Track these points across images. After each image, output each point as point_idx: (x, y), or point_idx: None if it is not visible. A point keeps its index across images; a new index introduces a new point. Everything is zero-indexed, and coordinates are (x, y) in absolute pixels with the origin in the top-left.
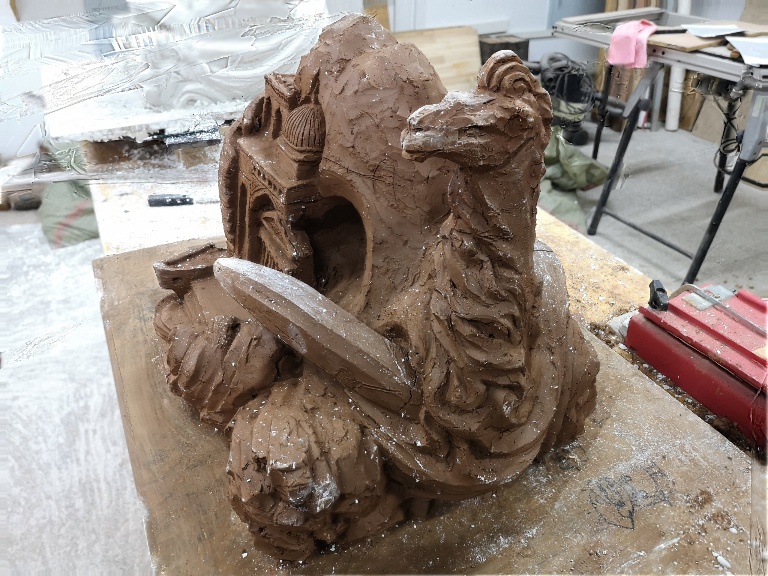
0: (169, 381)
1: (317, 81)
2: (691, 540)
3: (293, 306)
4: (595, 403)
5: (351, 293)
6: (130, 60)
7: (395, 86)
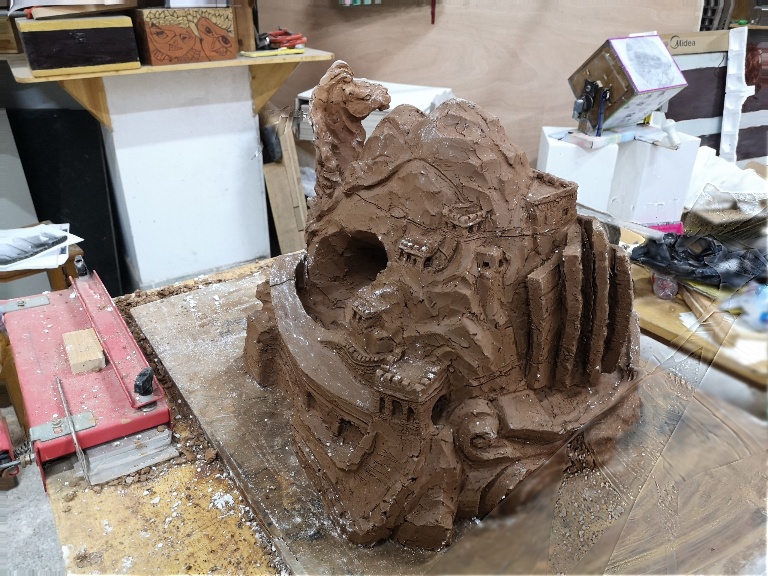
0: None
1: None
2: (228, 308)
3: None
4: None
5: None
6: None
7: None
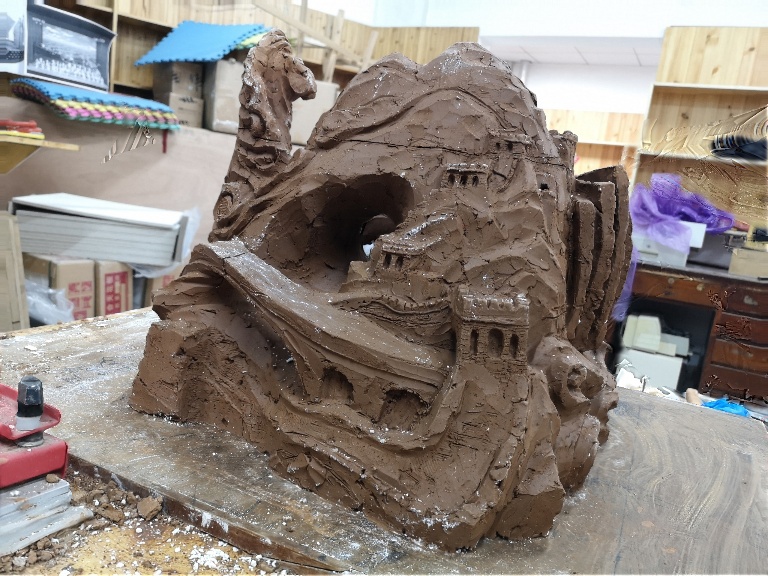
0: None
1: None
2: (57, 356)
3: None
4: None
5: None
6: (721, 160)
7: None
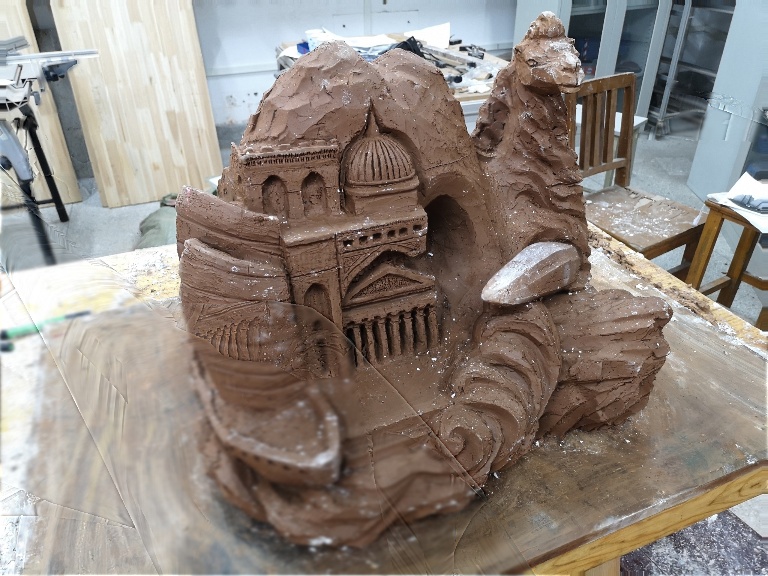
0: (480, 482)
1: (371, 112)
2: None
3: (558, 253)
4: None
5: (447, 280)
6: None
7: (435, 81)
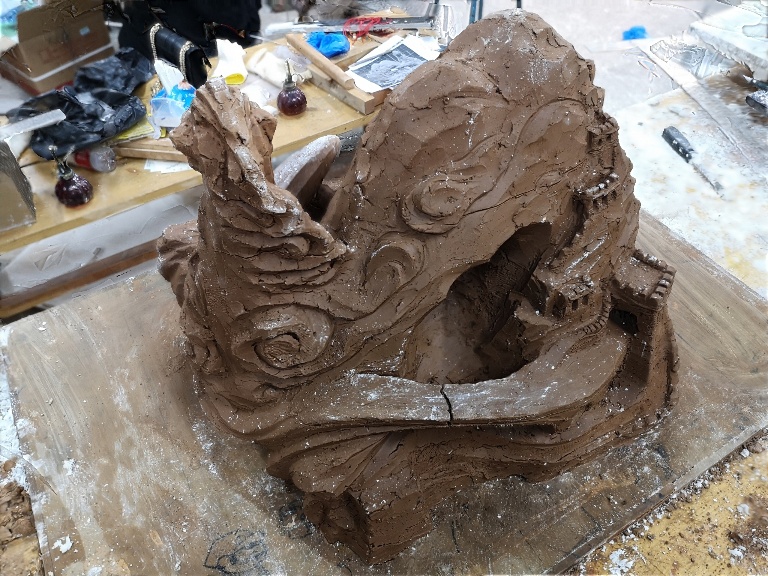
0: None
1: None
2: None
3: None
4: (369, 561)
5: None
6: None
7: None
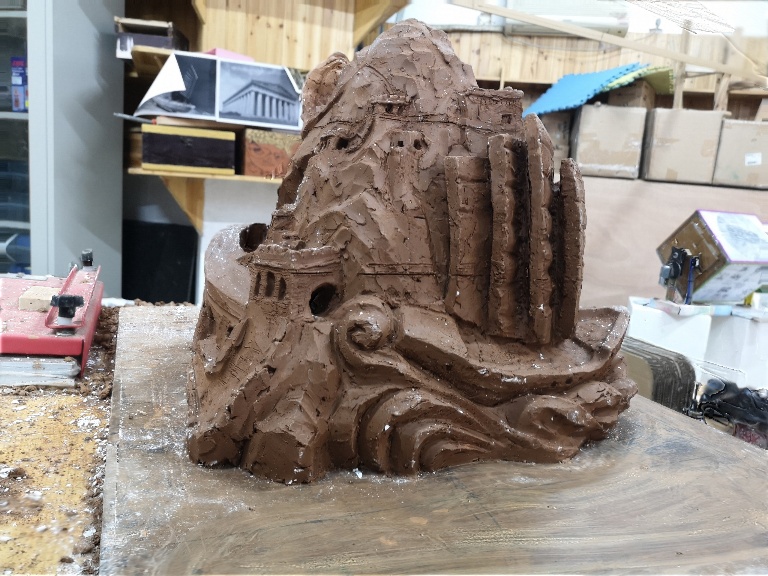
0: None
1: None
2: None
3: None
4: None
5: None
6: (767, 91)
7: None
